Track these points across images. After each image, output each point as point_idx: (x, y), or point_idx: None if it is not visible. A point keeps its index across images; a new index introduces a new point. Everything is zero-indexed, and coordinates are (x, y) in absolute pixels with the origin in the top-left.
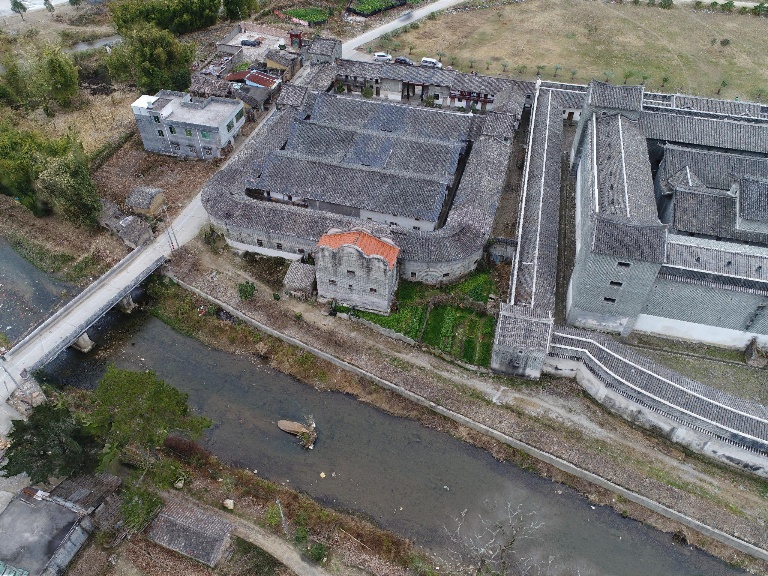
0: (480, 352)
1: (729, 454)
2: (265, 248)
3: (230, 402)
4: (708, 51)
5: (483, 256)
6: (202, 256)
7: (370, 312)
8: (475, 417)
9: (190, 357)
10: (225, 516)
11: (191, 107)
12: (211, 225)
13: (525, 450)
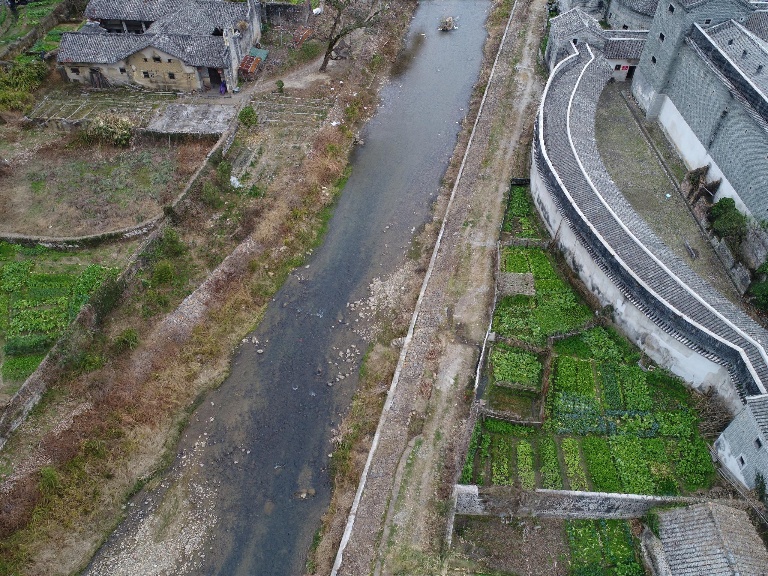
0: None
1: None
2: None
3: (455, 5)
4: None
5: None
6: None
7: None
8: (498, 65)
9: None
10: None
11: None
12: None
13: None
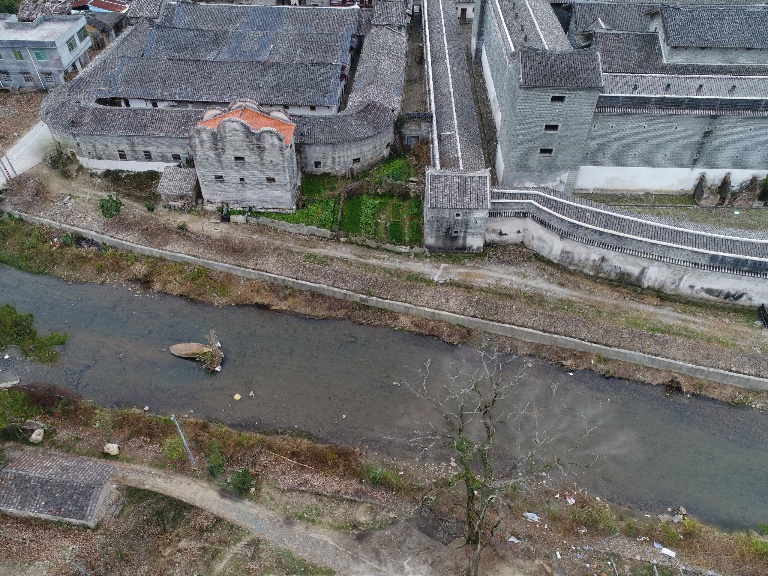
0: (410, 234)
1: (708, 285)
2: (130, 161)
3: (104, 337)
4: None
5: (395, 139)
6: (49, 182)
7: (272, 212)
8: (416, 301)
9: (44, 296)
10: None
11: (18, 28)
12: (57, 146)
13: (481, 327)
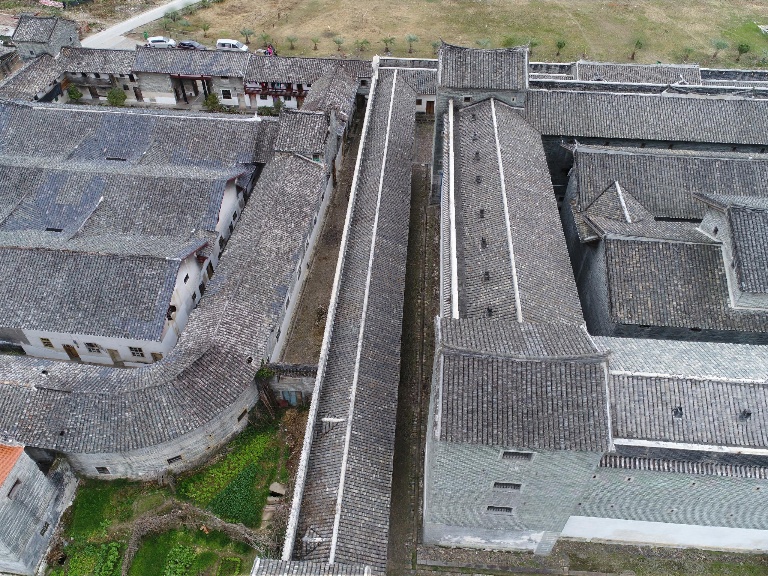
0: None
1: None
2: None
3: None
4: (610, 6)
5: (260, 397)
6: None
7: None
8: None
9: None
10: None
11: None
12: None
13: None
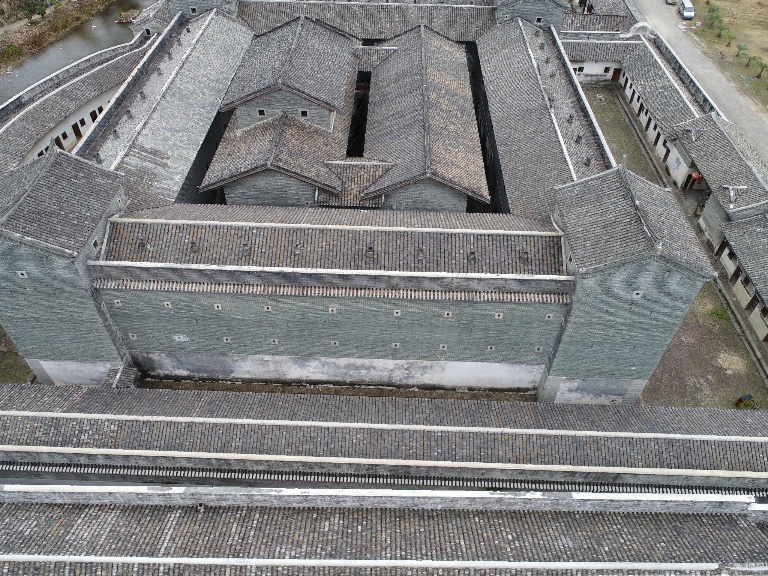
0: None
1: None
2: None
3: None
4: None
5: None
6: None
7: None
8: None
9: None
10: (68, 0)
11: None
12: None
13: None
